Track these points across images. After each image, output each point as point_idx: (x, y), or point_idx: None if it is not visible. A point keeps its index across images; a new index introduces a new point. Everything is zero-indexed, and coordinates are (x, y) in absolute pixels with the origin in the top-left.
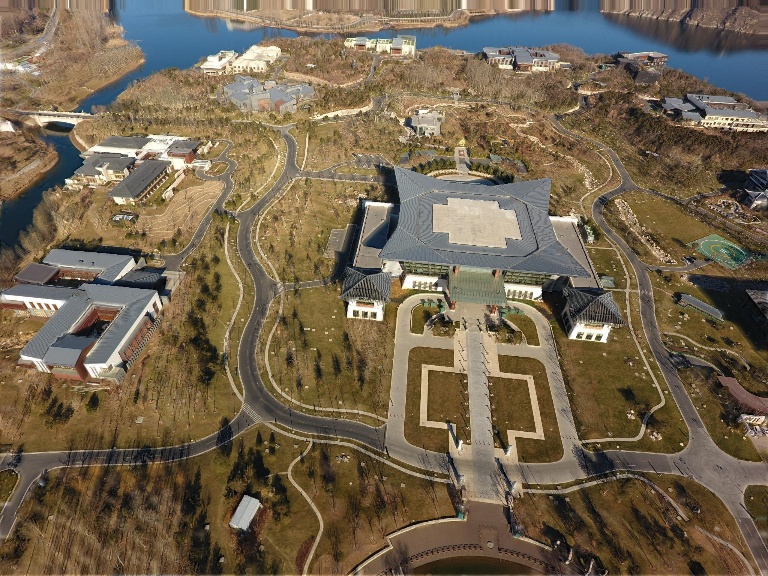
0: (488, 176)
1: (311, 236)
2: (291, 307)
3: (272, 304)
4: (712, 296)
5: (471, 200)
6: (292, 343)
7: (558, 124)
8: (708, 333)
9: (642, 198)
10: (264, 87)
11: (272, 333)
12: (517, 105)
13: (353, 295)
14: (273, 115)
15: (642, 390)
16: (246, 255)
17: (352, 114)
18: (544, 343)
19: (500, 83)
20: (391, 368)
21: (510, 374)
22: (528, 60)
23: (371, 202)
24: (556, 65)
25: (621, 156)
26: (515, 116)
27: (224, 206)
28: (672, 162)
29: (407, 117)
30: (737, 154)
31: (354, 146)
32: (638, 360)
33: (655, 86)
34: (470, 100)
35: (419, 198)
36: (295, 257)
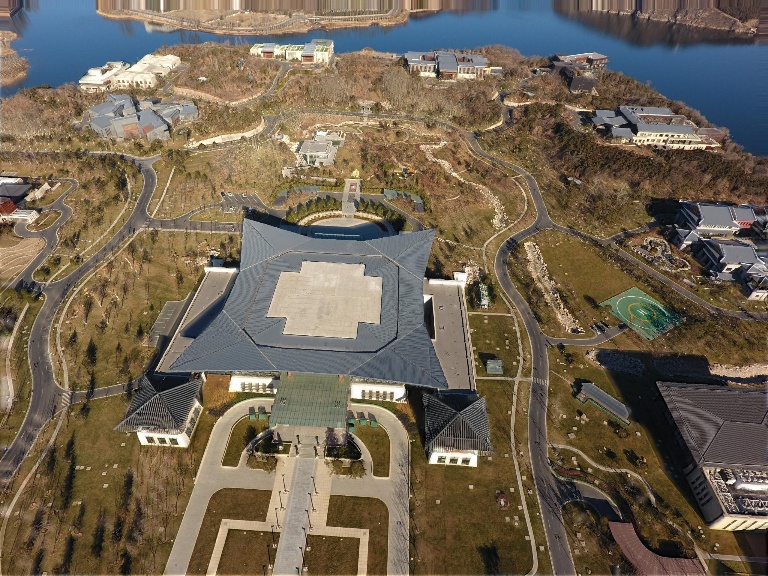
0: (377, 218)
1: (133, 315)
2: (69, 432)
3: (44, 428)
4: (621, 383)
5: (331, 264)
6: (50, 494)
7: (475, 144)
8: (608, 444)
9: (557, 240)
10: (139, 107)
11: (28, 478)
12: (431, 122)
13: (135, 423)
14: (136, 145)
15: (510, 548)
16: (36, 349)
17: (235, 139)
18: (396, 471)
19: (418, 95)
20: (177, 530)
21: (339, 529)
22: (452, 67)
23: (211, 268)
24: (486, 70)
25: (540, 184)
26: (429, 135)
27: (33, 275)
28: (595, 192)
29: (302, 140)
30: (669, 179)
31: (225, 182)
32: (513, 494)
33: (587, 95)
34: (381, 116)
35: (266, 263)
36: (100, 350)
